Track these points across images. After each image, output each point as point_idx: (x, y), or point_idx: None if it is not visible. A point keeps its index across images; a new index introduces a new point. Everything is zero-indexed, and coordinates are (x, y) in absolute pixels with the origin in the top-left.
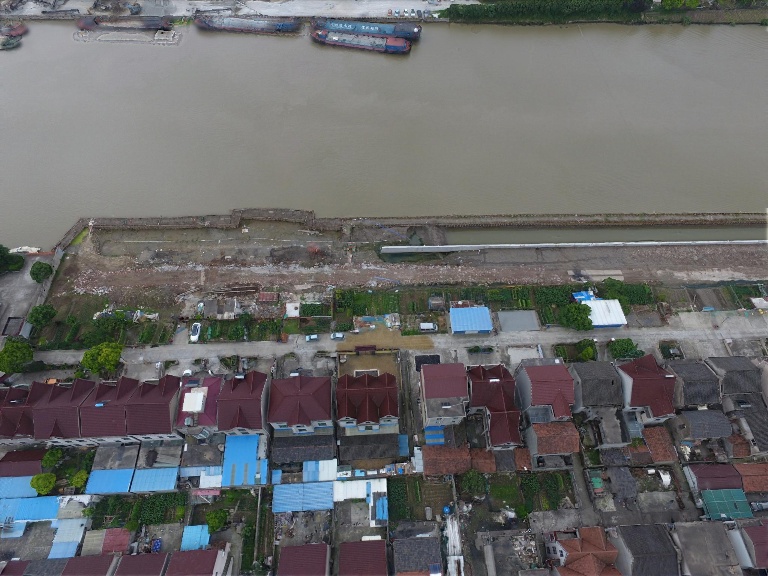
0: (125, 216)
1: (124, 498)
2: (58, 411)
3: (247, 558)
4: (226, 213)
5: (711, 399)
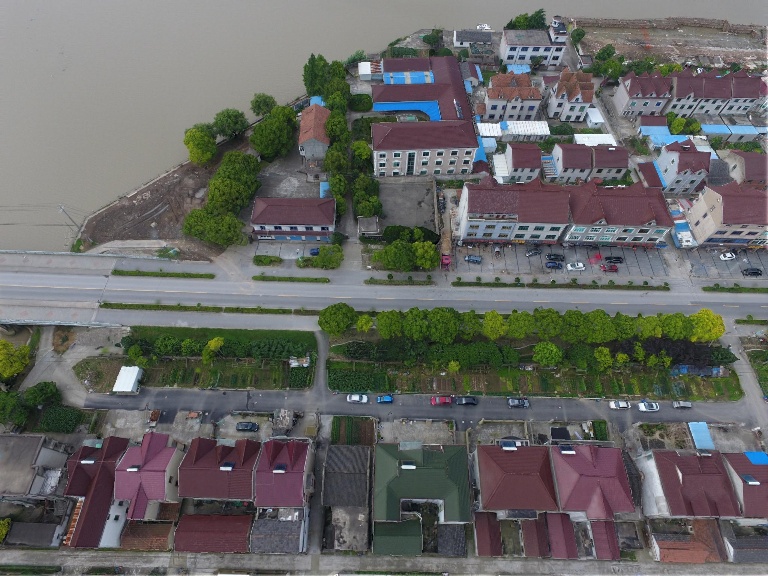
0: (591, 18)
1: (722, 141)
2: (692, 79)
3: None
4: None
5: None
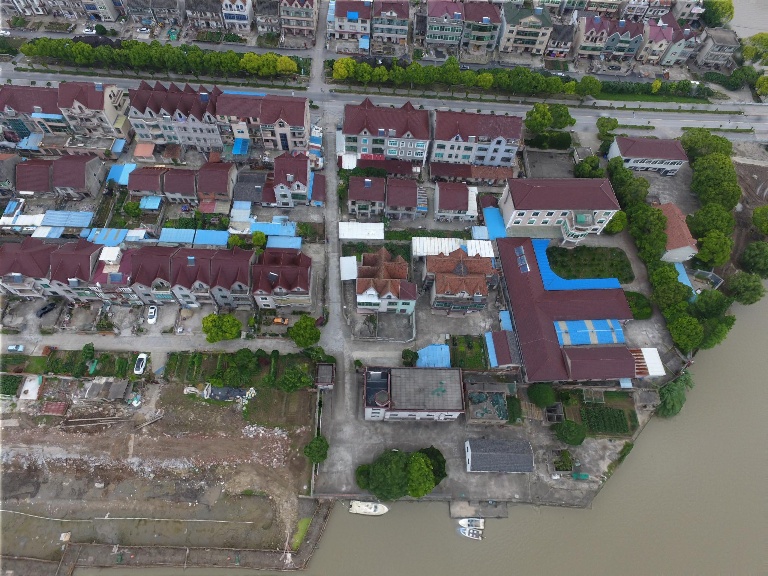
0: (241, 575)
1: None
2: None
3: (123, 197)
4: (84, 574)
5: None
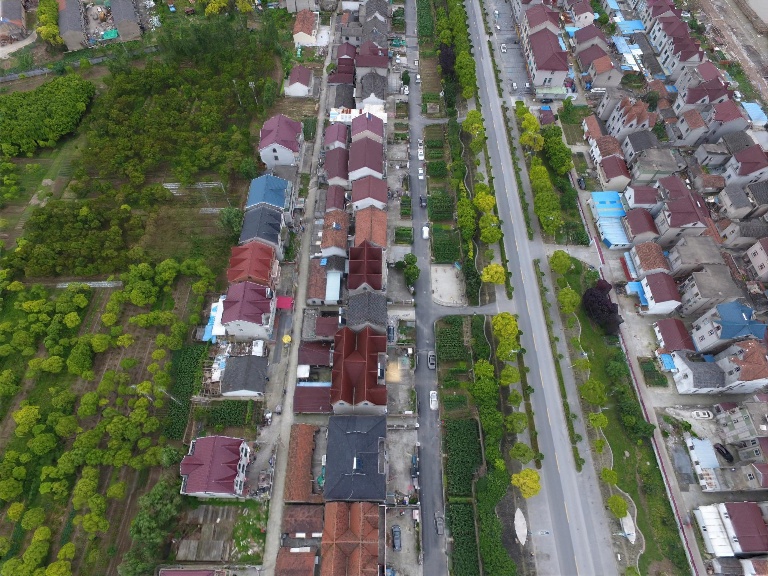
0: None
1: (600, 1)
2: None
3: None
4: None
5: (761, 200)
